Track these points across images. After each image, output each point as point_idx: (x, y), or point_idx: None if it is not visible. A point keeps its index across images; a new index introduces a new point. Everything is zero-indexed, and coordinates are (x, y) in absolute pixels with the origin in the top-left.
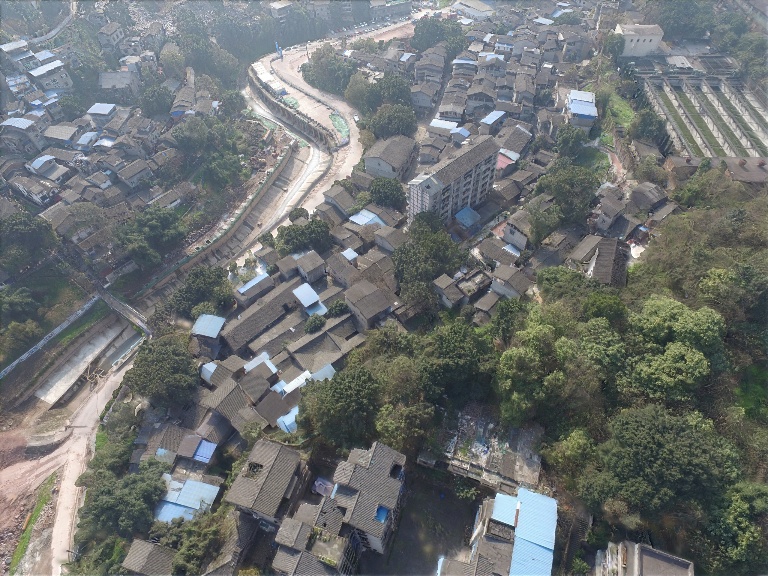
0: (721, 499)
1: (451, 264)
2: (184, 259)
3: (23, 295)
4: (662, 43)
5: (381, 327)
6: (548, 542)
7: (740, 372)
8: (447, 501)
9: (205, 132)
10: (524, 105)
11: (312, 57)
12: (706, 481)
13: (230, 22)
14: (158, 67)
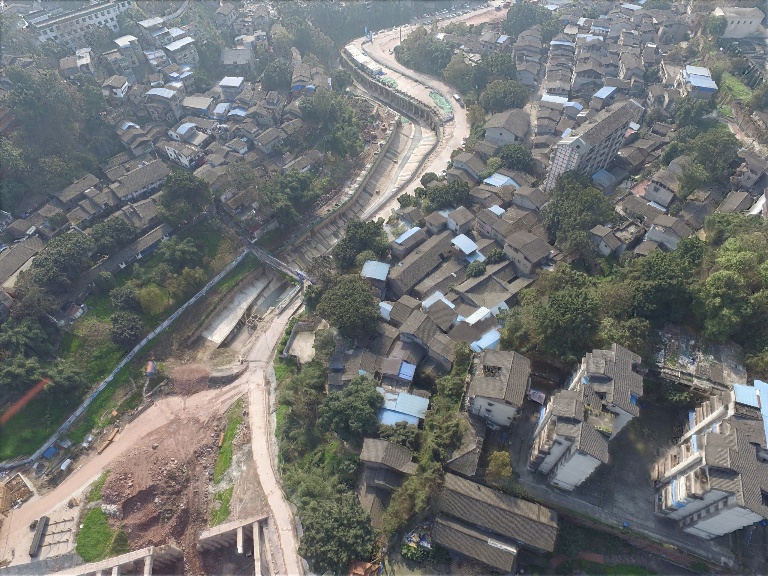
0: None
1: (605, 216)
2: (318, 220)
3: (190, 245)
4: (760, 25)
5: None
6: None
7: None
8: (648, 410)
9: (330, 104)
10: (635, 81)
11: (409, 39)
12: None
13: (325, 6)
14: (269, 46)
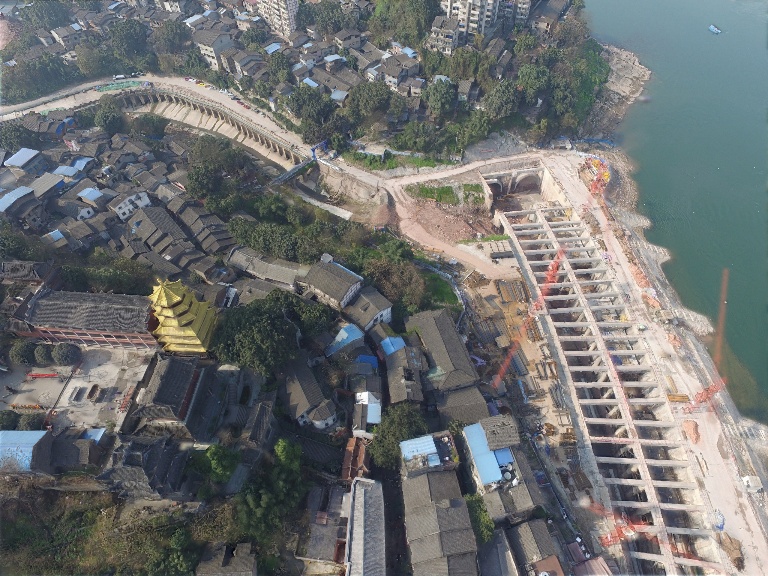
0: None
1: (338, 7)
2: None
3: None
4: None
5: (364, 36)
6: None
7: None
8: None
9: None
10: None
11: (5, 75)
12: None
13: None
14: None
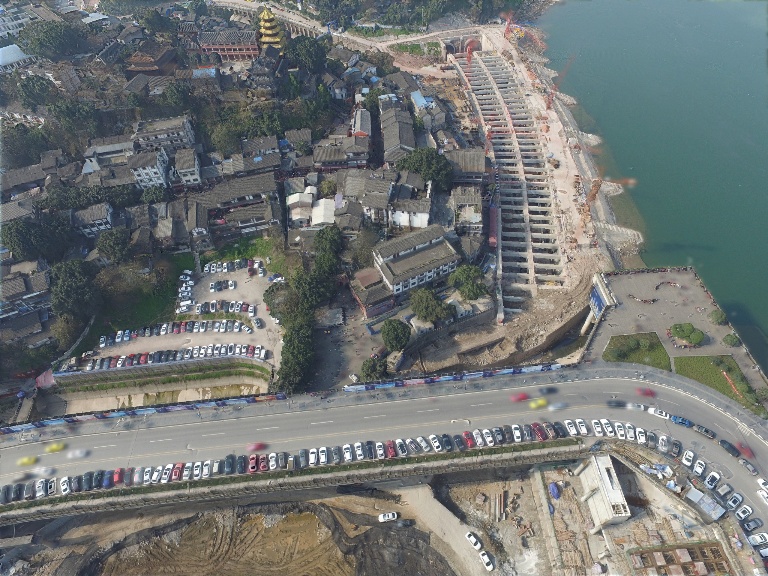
0: None
1: None
2: None
3: None
4: None
5: None
6: None
7: None
8: None
9: None
10: None
11: None
12: None
13: None
14: None
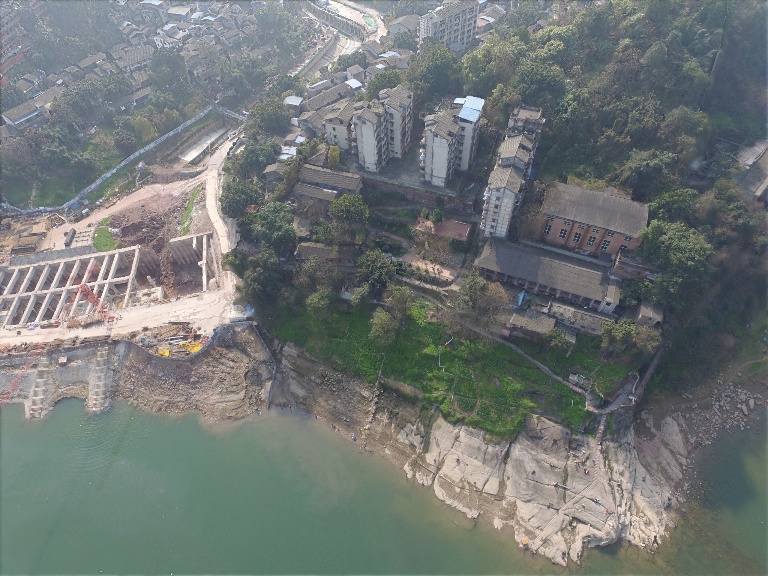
0: (563, 97)
1: None
2: None
3: (170, 96)
4: None
5: None
6: (478, 108)
7: (587, 64)
8: None
9: (278, 13)
10: None
11: None
12: (553, 82)
13: None
14: None
